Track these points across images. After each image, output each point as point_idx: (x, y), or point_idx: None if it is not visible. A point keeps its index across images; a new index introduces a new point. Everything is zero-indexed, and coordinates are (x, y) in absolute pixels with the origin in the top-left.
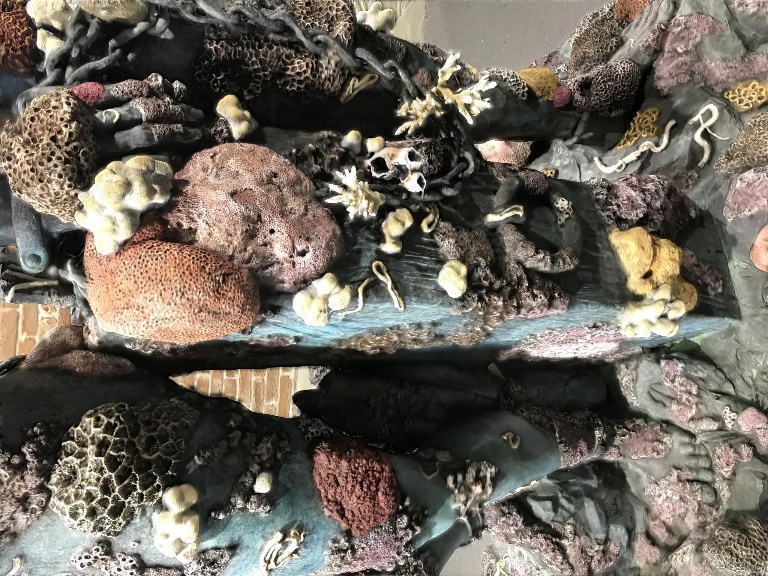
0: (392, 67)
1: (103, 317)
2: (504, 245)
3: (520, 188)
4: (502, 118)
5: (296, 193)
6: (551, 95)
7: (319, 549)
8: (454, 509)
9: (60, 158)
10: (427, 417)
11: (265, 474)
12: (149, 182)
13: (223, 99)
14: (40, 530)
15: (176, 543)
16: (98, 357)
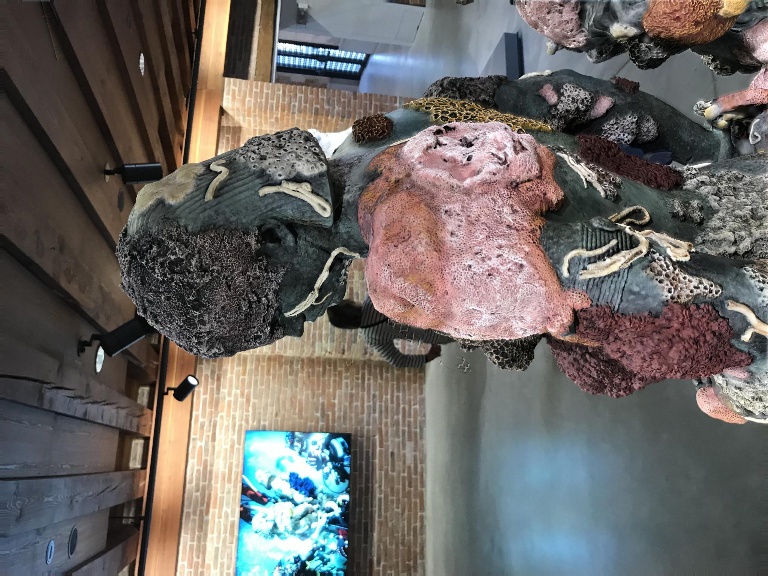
0: None
1: None
2: None
3: None
4: None
5: None
6: None
7: None
8: None
9: None
10: None
11: None
12: None
13: None
14: None
15: None
16: (760, 65)
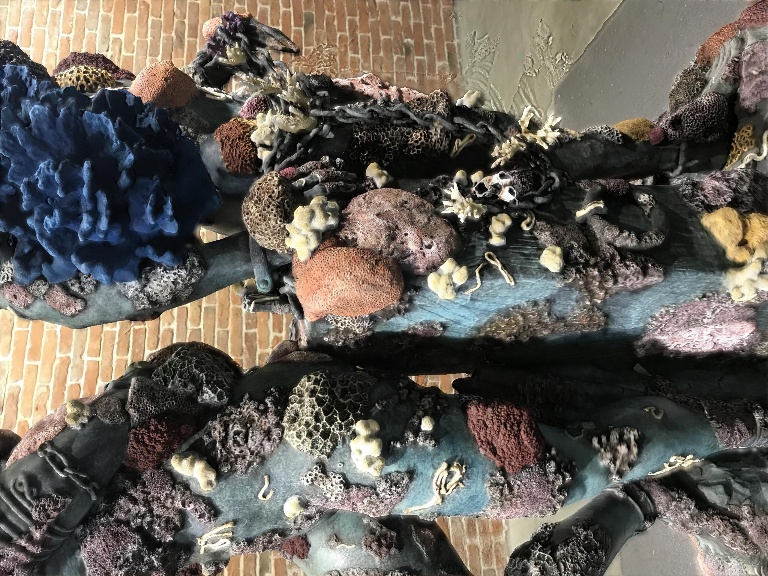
0: (482, 125)
1: (306, 301)
2: (594, 233)
3: (603, 192)
4: (604, 162)
5: (421, 212)
6: (646, 136)
7: (480, 481)
8: (603, 466)
9: (274, 205)
10: (576, 407)
11: (428, 417)
12: (325, 211)
13: (369, 166)
14: (279, 455)
15: (367, 458)
16: (308, 354)
